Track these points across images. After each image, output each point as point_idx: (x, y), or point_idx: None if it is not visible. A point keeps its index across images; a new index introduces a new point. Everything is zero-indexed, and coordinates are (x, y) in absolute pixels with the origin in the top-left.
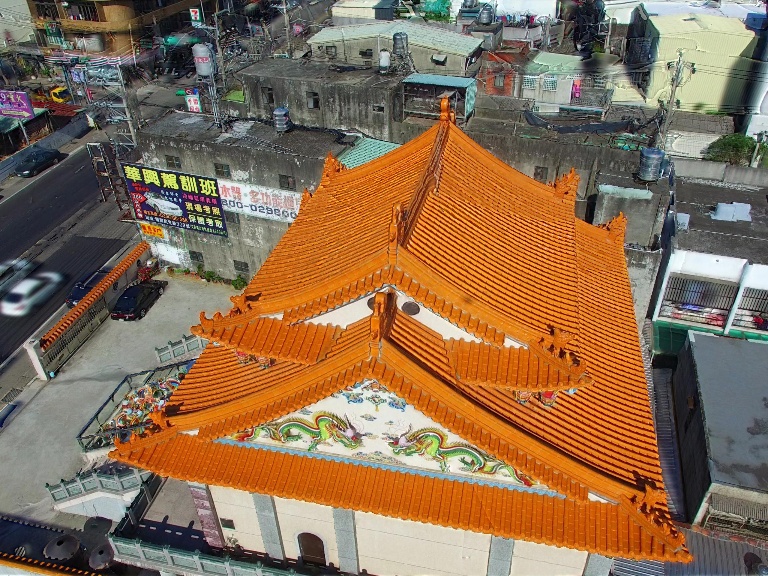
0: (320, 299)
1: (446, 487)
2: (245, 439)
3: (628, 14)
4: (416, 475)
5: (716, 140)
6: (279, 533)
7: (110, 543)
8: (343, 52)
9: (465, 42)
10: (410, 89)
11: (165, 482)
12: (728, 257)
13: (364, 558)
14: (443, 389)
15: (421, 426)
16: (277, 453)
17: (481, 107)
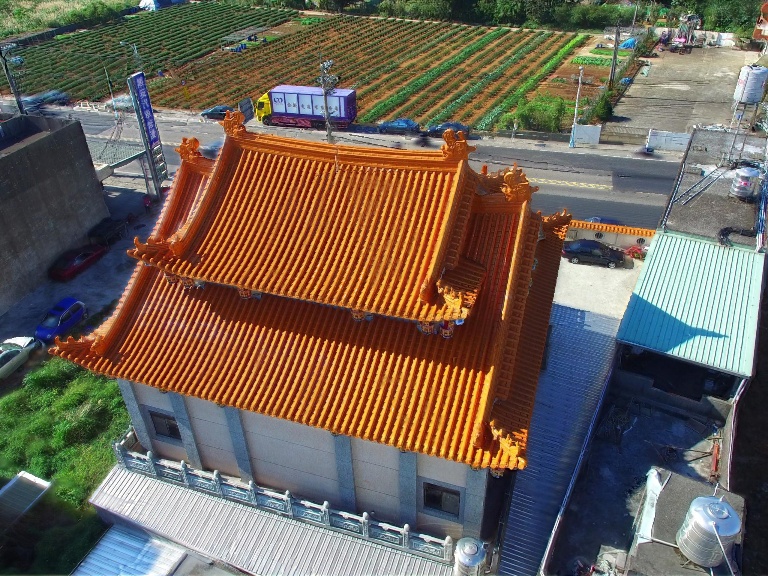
0: None
1: None
2: None
3: None
4: None
5: None
6: None
7: None
8: None
9: None
10: None
11: None
12: None
13: None
14: None
15: None
16: None
17: None
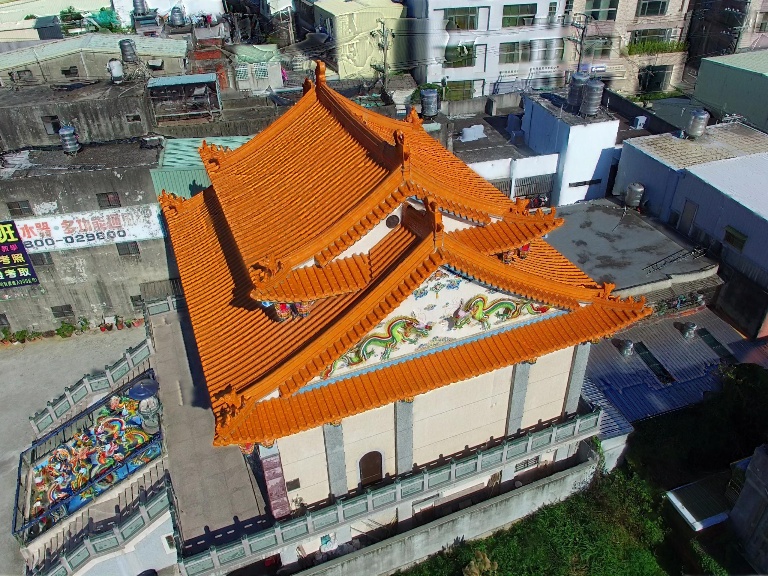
0: (347, 233)
1: (489, 342)
2: (328, 375)
3: (289, 4)
4: (465, 344)
5: (414, 91)
6: (344, 467)
7: (180, 569)
8: (41, 75)
9: (172, 45)
10: (157, 93)
11: (177, 504)
12: (499, 160)
13: (416, 452)
14: (485, 258)
15: (469, 298)
16: (353, 378)
17: (227, 99)
